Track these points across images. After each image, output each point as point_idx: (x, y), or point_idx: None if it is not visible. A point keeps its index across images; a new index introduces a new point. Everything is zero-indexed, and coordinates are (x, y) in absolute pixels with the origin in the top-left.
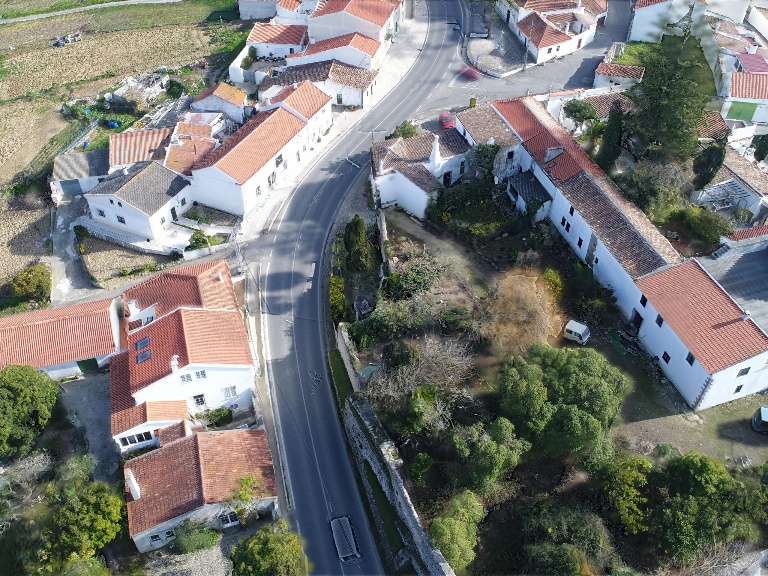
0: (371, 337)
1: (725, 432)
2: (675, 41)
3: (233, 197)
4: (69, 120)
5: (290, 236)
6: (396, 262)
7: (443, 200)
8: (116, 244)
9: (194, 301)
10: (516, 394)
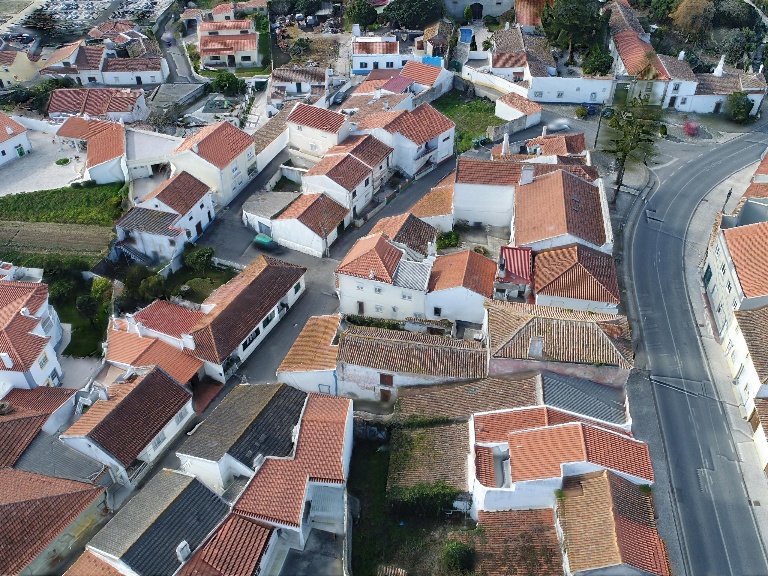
0: None
1: None
2: None
3: None
4: None
5: None
6: None
7: None
8: None
9: None
10: None
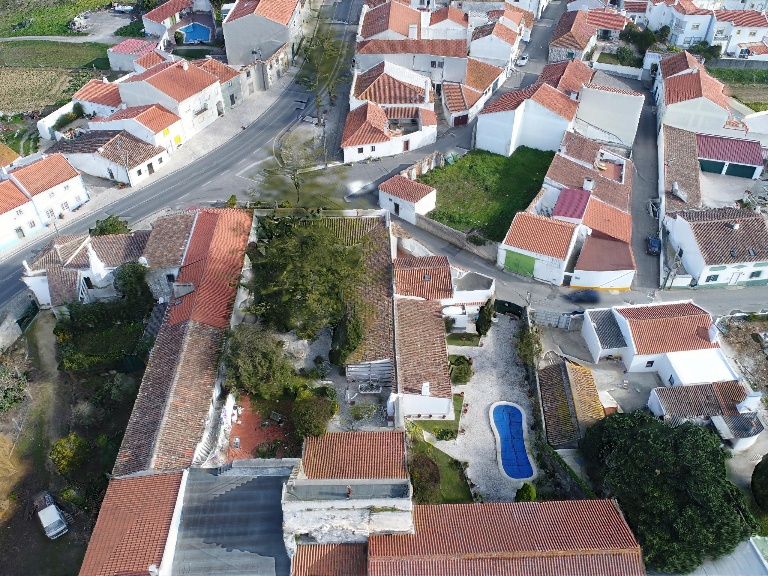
0: None
1: None
2: (529, 156)
3: None
4: None
5: None
6: None
7: (73, 317)
8: None
9: None
10: None
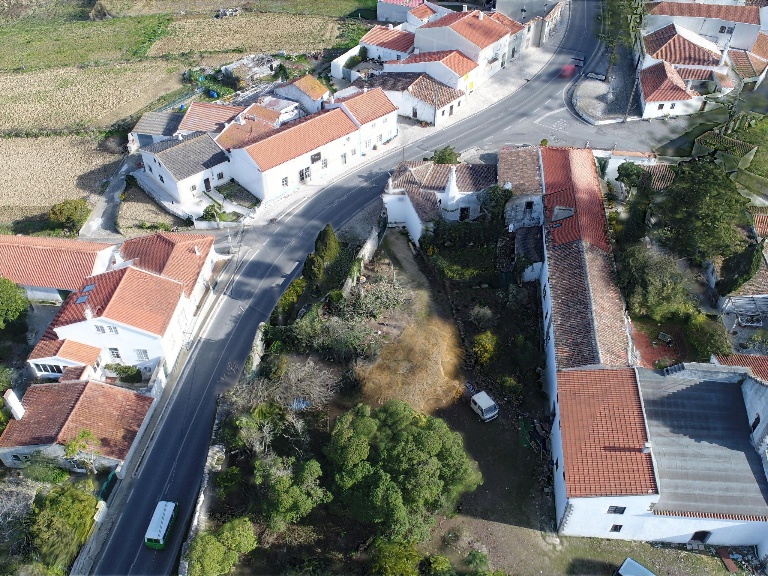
0: (287, 345)
1: (578, 569)
2: None
3: (257, 181)
4: (185, 83)
5: (292, 231)
6: (363, 282)
7: (438, 233)
8: (153, 199)
9: (160, 265)
10: (337, 442)
